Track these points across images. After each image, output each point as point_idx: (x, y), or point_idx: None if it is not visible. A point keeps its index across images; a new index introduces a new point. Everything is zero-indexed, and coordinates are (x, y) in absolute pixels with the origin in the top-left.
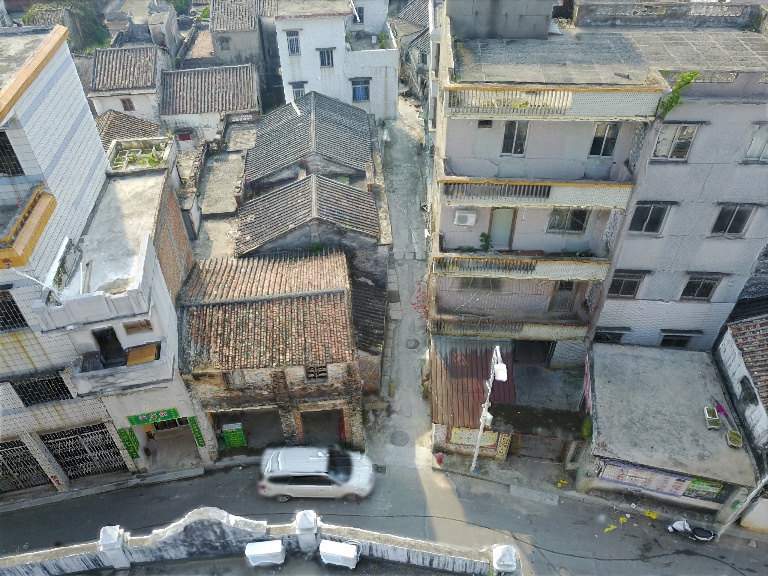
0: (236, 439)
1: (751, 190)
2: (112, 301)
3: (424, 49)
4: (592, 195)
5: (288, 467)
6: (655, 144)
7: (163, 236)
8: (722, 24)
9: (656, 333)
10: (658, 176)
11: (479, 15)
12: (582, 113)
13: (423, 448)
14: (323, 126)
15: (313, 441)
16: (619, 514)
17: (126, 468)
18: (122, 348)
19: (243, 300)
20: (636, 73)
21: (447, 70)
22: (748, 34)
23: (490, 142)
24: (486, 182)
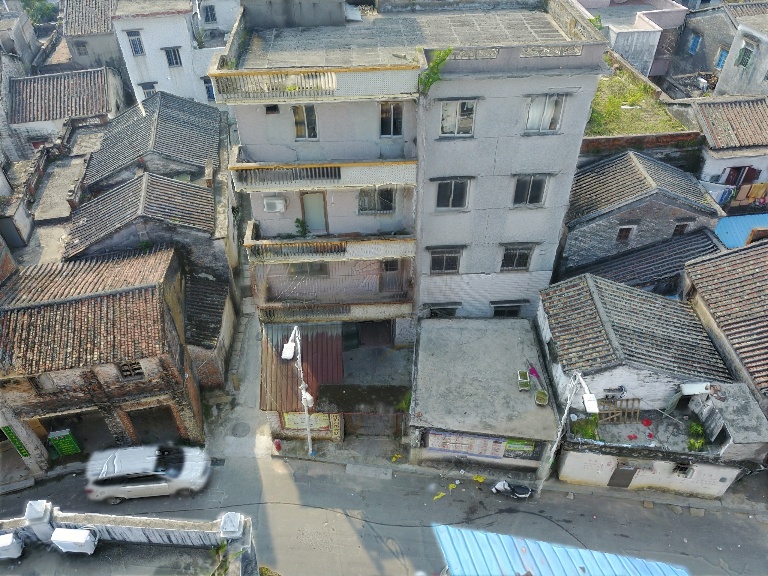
0: (67, 446)
1: (539, 161)
2: None
3: None
4: (382, 173)
5: (124, 469)
6: (440, 121)
7: None
8: (515, 6)
9: (486, 305)
10: (450, 152)
11: (273, 4)
12: (350, 93)
13: (264, 437)
14: (166, 125)
15: (152, 441)
16: (449, 481)
17: None
18: None
19: (50, 302)
20: (414, 54)
21: (219, 57)
22: (533, 14)
23: (282, 128)
24: (276, 167)
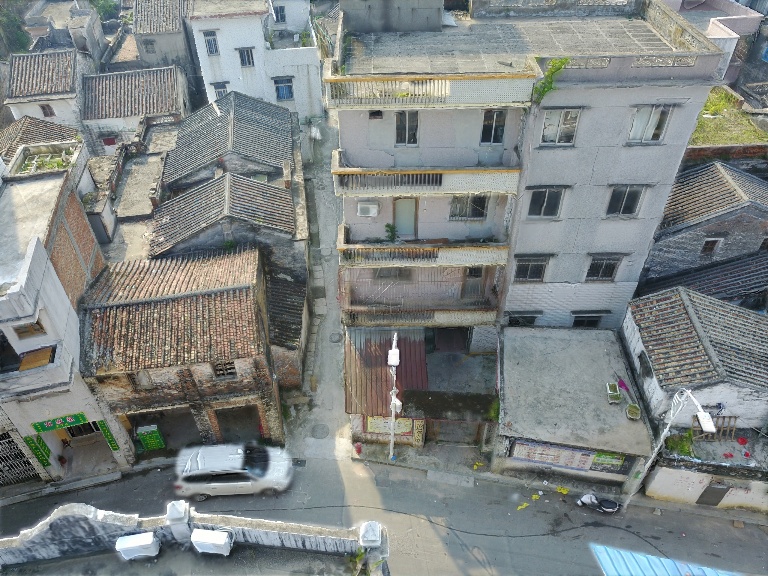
0: (153, 441)
1: (638, 171)
2: None
3: None
4: (483, 181)
5: (207, 466)
6: (542, 130)
7: (60, 239)
8: (610, 13)
9: (567, 315)
10: (549, 161)
11: (372, 9)
12: (462, 101)
13: (343, 439)
14: (242, 125)
15: (233, 439)
16: (532, 492)
17: (40, 477)
18: None
19: (147, 300)
20: (519, 61)
21: (330, 63)
22: (632, 22)
23: (383, 133)
24: (379, 172)
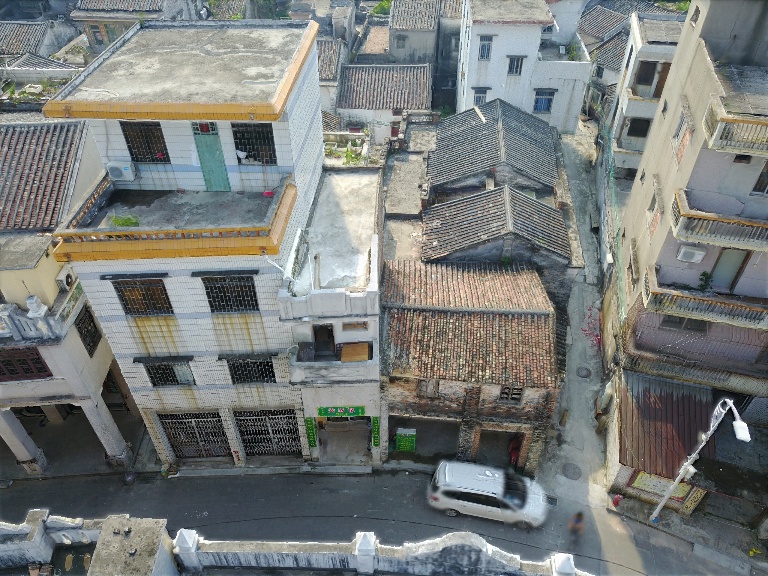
0: (407, 444)
1: None
2: (350, 299)
3: (602, 62)
4: None
5: (455, 481)
6: None
7: None
8: None
9: None
10: None
11: (737, 39)
12: None
13: (597, 486)
14: (510, 136)
15: (481, 458)
16: None
17: (299, 454)
18: (329, 341)
19: (444, 309)
20: None
21: (719, 99)
22: None
23: (743, 178)
24: (737, 222)
